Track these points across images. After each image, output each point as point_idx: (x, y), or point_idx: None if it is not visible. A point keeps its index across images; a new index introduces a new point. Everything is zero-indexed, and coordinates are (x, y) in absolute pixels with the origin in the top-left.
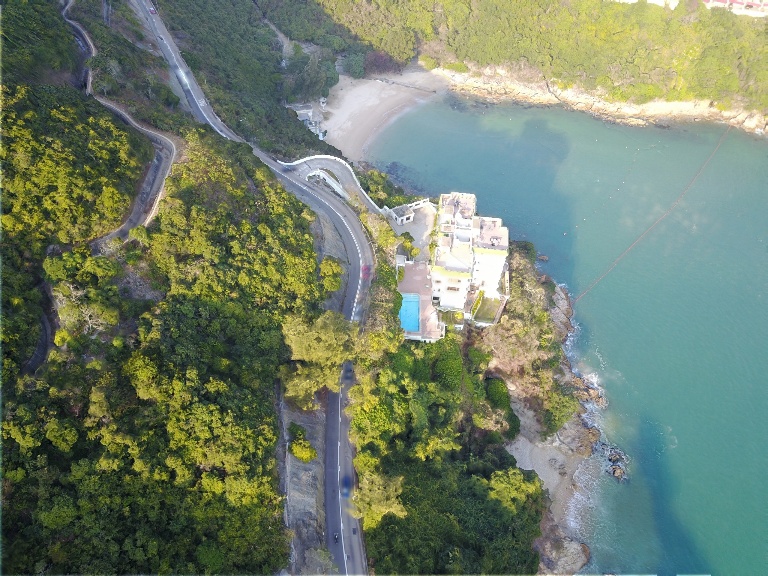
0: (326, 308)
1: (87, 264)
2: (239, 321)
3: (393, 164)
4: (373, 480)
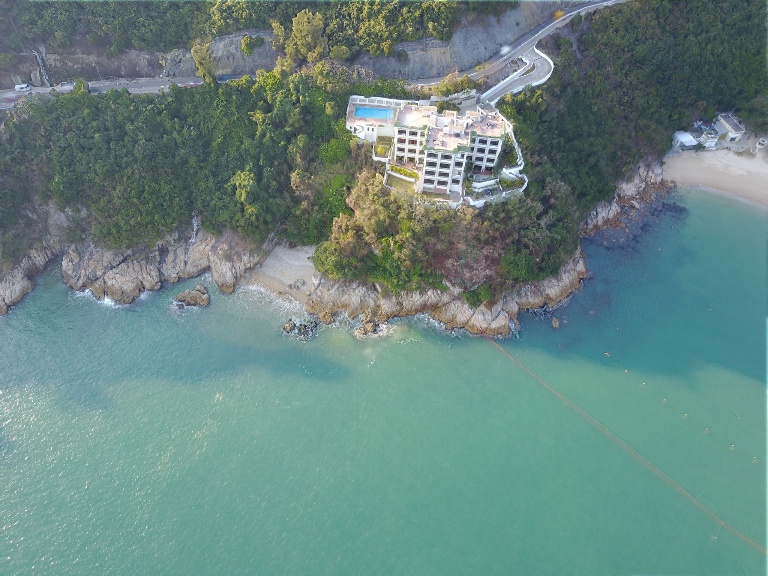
0: (362, 60)
1: None
2: (329, 7)
3: (682, 208)
4: None
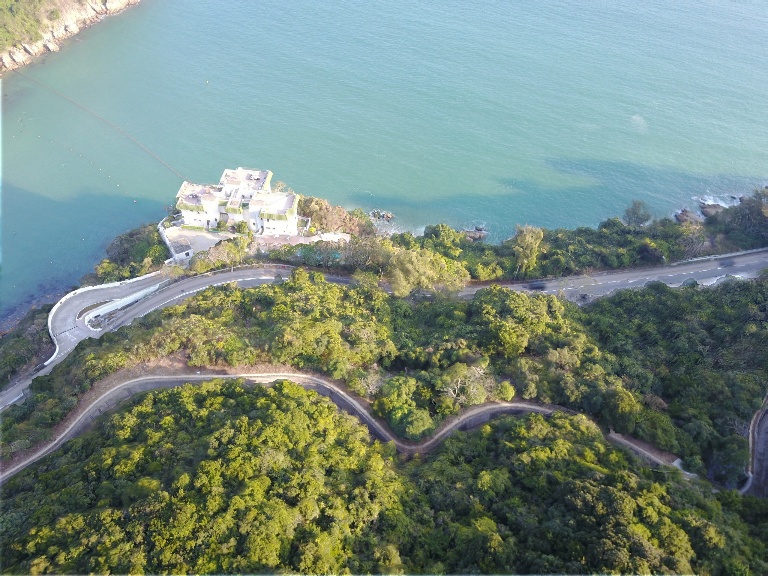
0: None
1: (404, 395)
2: None
3: None
4: (493, 268)
